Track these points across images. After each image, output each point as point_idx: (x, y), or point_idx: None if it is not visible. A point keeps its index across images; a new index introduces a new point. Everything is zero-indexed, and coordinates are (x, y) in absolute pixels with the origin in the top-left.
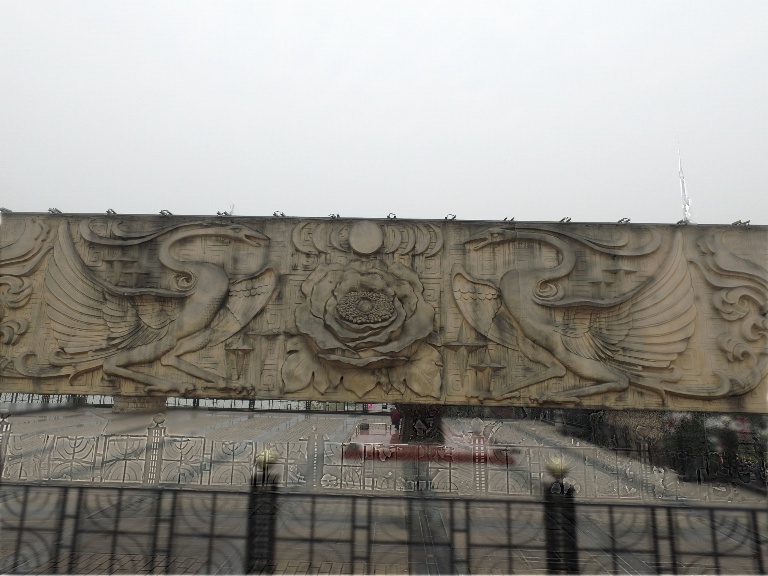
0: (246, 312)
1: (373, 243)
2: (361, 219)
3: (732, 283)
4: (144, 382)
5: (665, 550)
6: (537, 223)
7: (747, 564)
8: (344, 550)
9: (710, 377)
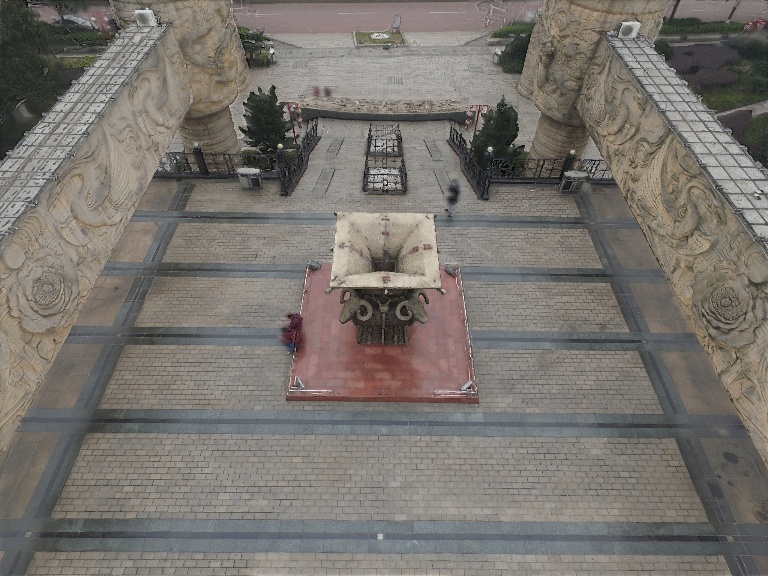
0: (4, 361)
1: (20, 255)
2: (2, 249)
3: (125, 135)
4: (1, 449)
5: (142, 250)
6: (65, 168)
7: (162, 232)
8: (100, 371)
9: (137, 182)
